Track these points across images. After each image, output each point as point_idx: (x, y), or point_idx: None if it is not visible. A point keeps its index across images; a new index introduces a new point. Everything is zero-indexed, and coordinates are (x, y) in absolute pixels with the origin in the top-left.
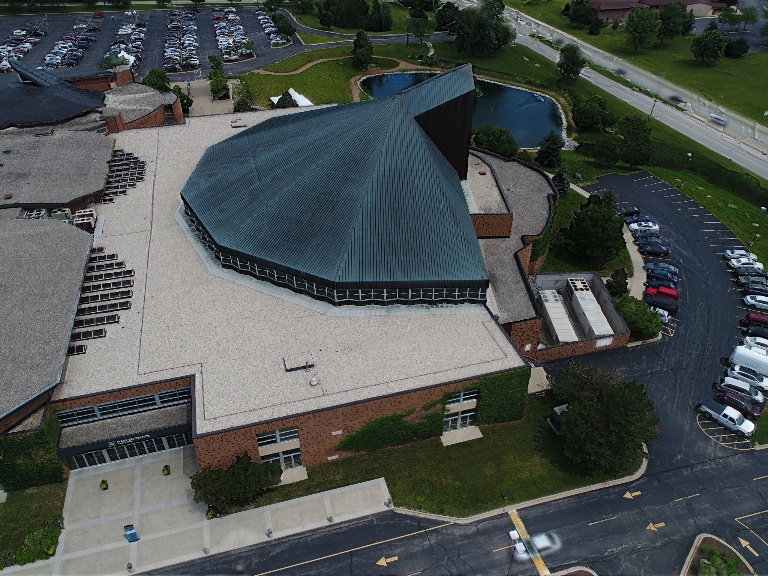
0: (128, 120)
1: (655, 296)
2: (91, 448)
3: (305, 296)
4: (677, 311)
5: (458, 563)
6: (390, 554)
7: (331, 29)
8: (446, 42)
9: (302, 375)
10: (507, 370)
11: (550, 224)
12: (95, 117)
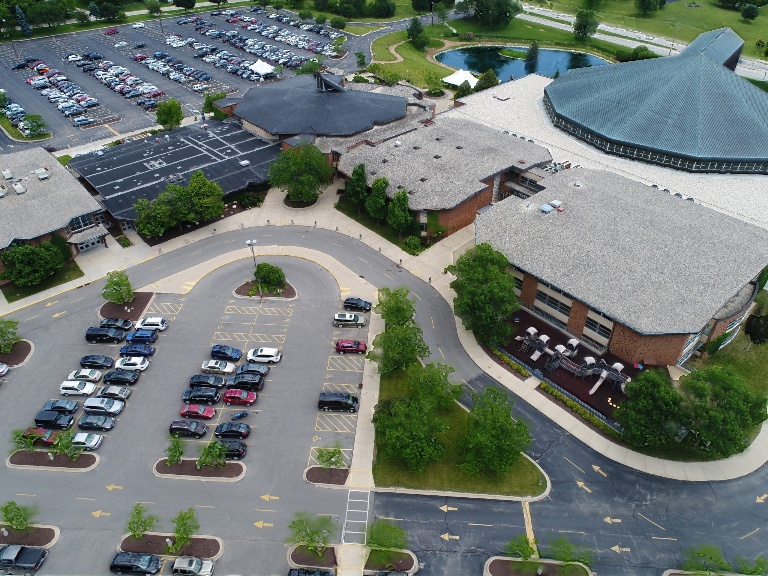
0: None
1: None
2: None
3: None
4: None
5: None
6: None
7: (351, 20)
8: (455, 20)
9: None
10: None
11: None
12: None
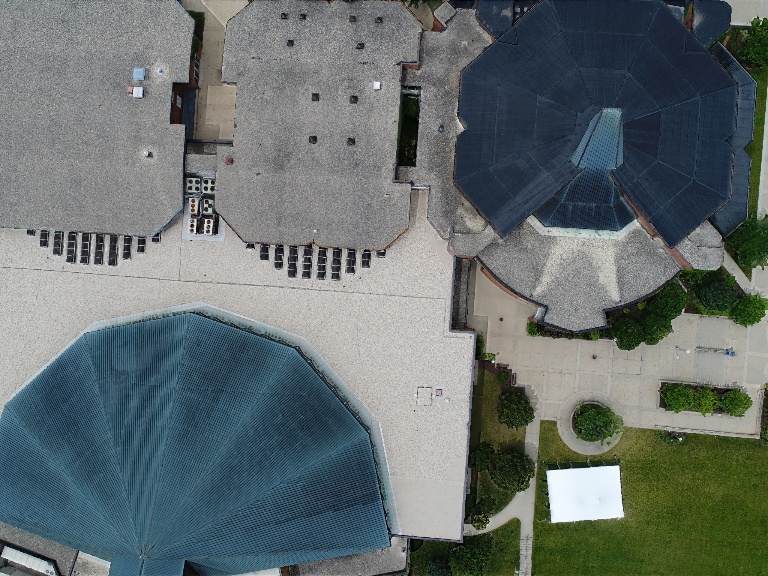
0: (493, 262)
1: None
2: None
3: None
4: None
5: None
6: None
7: None
8: None
9: None
10: None
11: None
12: None
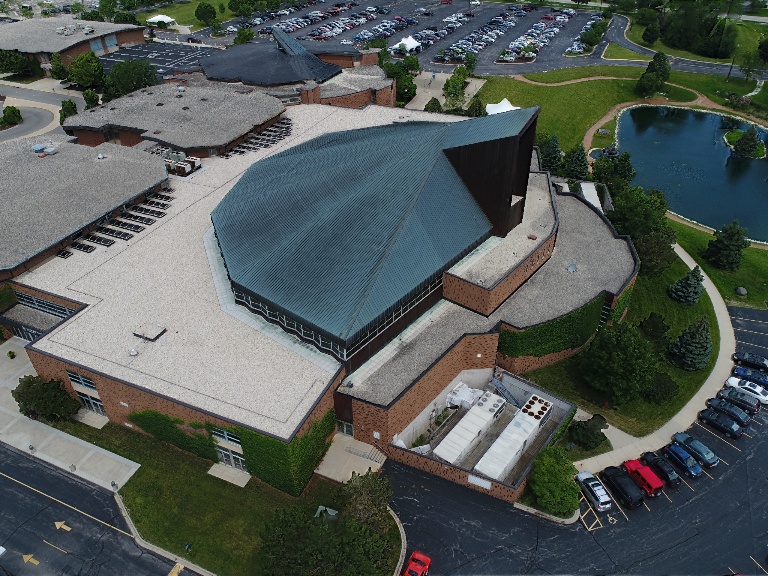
0: (328, 96)
1: (631, 474)
2: (14, 324)
3: (230, 284)
4: (638, 507)
5: (94, 569)
6: (70, 523)
7: (653, 46)
8: None
9: (138, 343)
10: (264, 433)
11: (552, 323)
12: (294, 87)
